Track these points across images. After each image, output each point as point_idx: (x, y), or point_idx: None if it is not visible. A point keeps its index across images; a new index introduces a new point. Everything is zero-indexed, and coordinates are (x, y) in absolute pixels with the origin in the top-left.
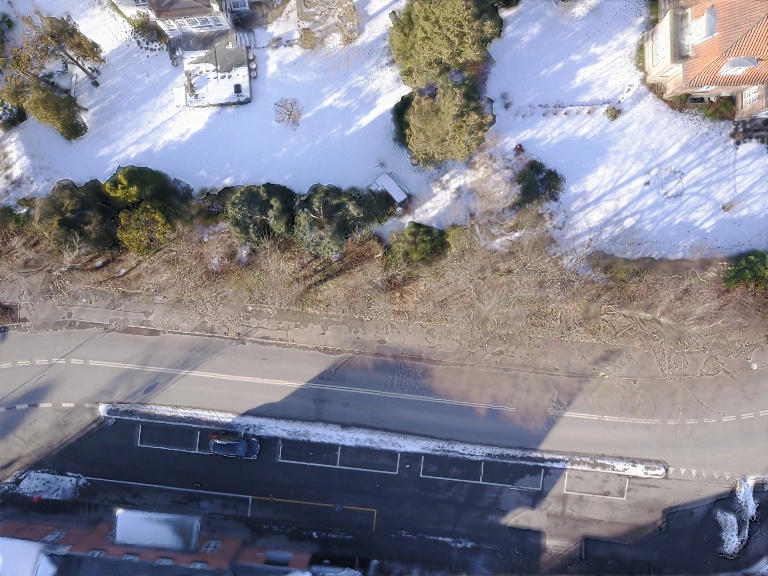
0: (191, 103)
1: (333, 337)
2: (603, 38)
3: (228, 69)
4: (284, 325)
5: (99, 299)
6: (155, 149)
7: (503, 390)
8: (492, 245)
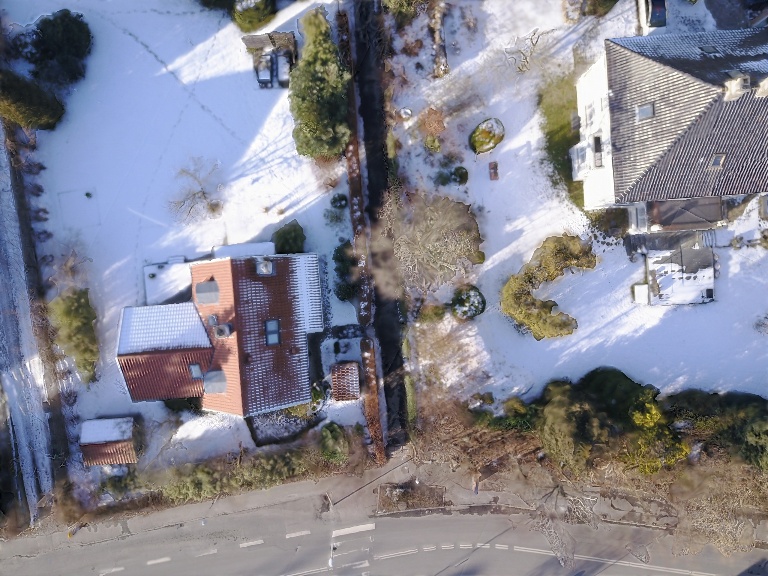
0: (654, 303)
1: (764, 531)
2: None
3: (694, 270)
4: None
5: None
6: (607, 344)
7: None
8: None
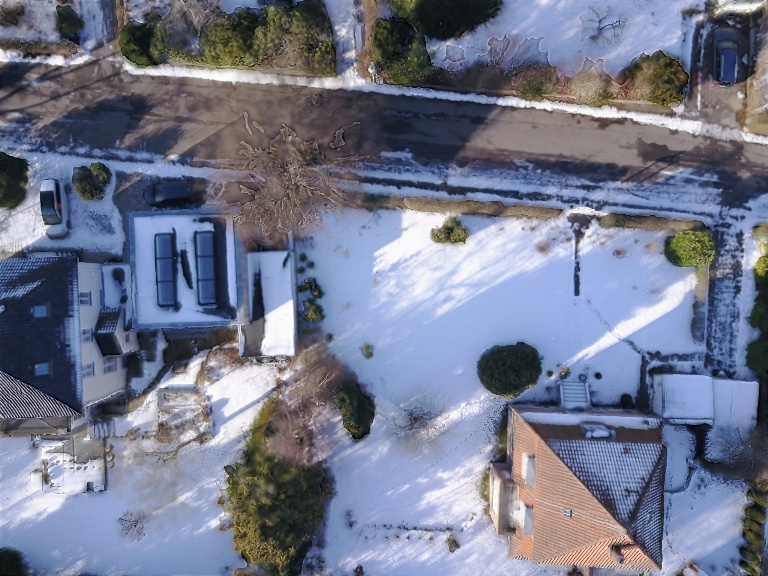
0: (47, 490)
1: None
2: (451, 463)
3: (84, 460)
4: None
5: None
6: (12, 525)
7: None
8: None
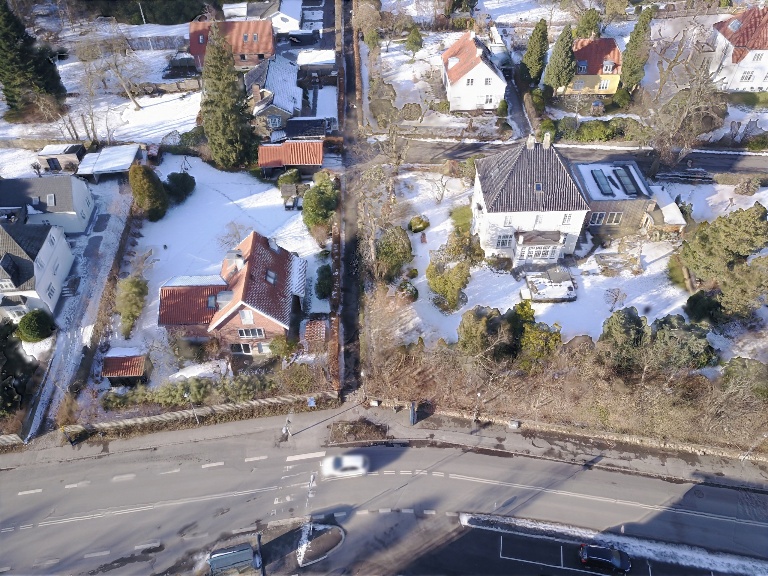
0: (535, 297)
1: (673, 468)
2: None
3: (559, 282)
4: (625, 455)
5: (458, 426)
6: None
7: None
8: None
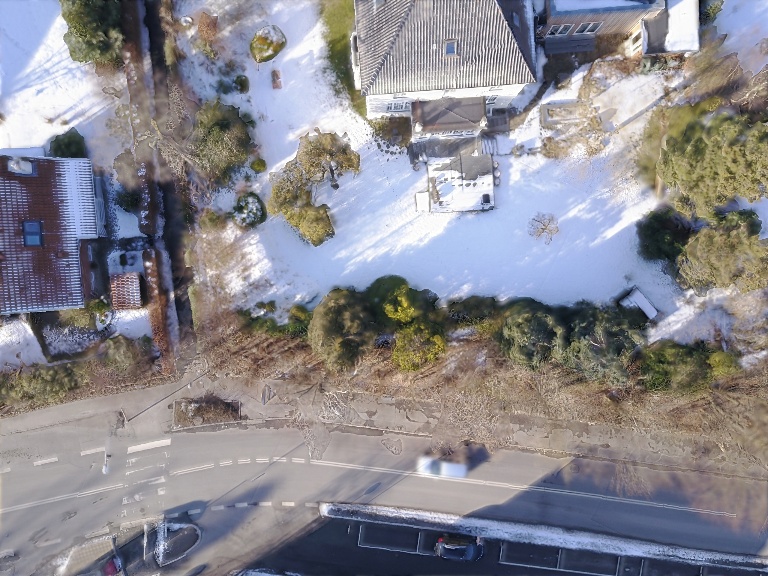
0: (435, 210)
1: (557, 440)
2: None
3: (473, 177)
4: None
5: None
6: (393, 253)
7: (724, 496)
8: (738, 362)
